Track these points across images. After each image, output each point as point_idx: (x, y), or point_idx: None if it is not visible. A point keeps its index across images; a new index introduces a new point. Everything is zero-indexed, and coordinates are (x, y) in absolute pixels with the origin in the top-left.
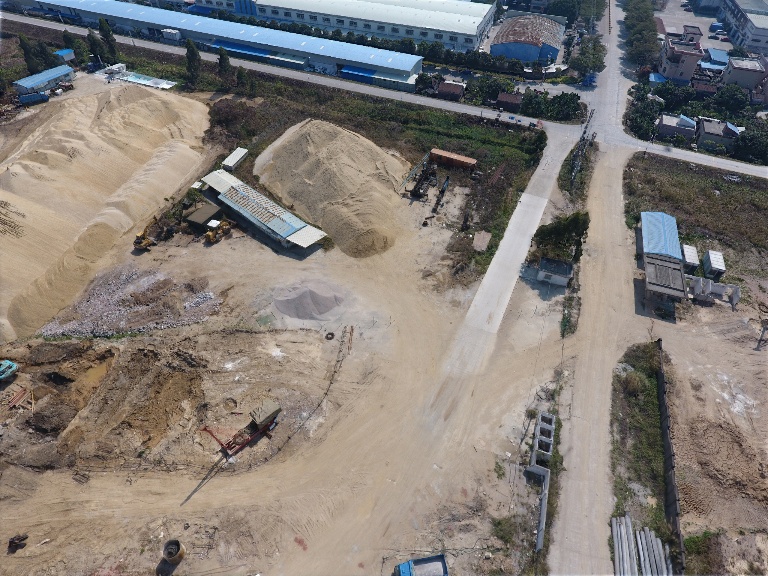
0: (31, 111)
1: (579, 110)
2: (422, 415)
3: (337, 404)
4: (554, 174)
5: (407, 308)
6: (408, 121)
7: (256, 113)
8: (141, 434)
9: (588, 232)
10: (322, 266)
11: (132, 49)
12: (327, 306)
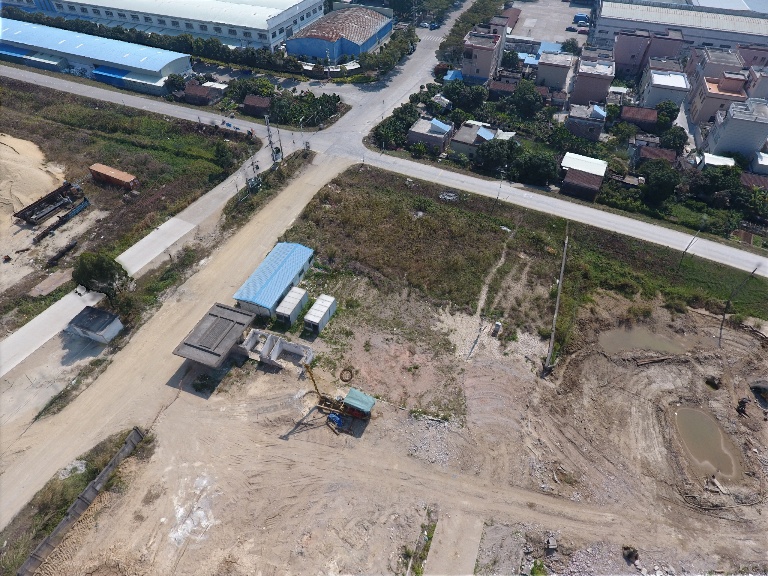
0: None
1: (335, 114)
2: None
3: None
4: (231, 193)
5: None
6: (117, 129)
7: None
8: None
9: (207, 268)
10: None
11: None
12: None
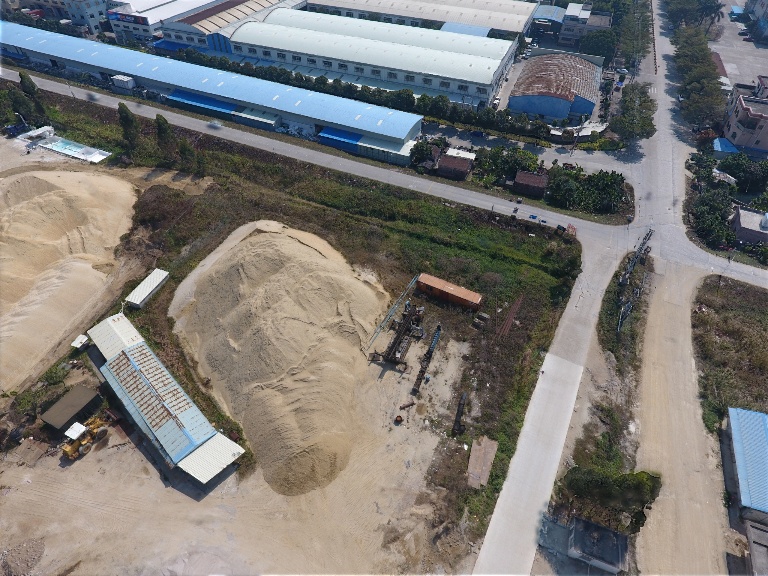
0: None
1: (623, 197)
2: None
3: None
4: (592, 316)
5: None
6: (395, 216)
7: (195, 206)
8: None
9: (646, 440)
10: (228, 515)
11: (71, 103)
12: None
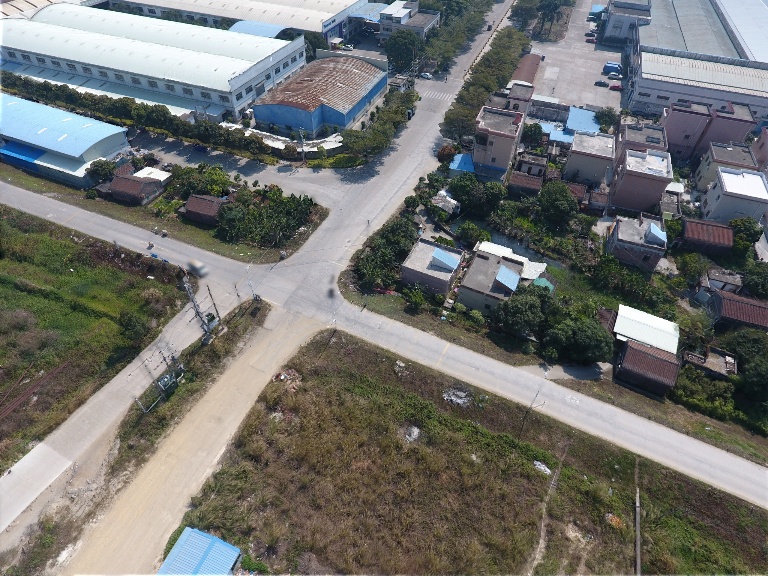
0: None
1: (306, 226)
2: None
3: None
4: (138, 388)
5: None
6: (4, 254)
7: None
8: None
9: (67, 575)
10: None
11: None
12: None
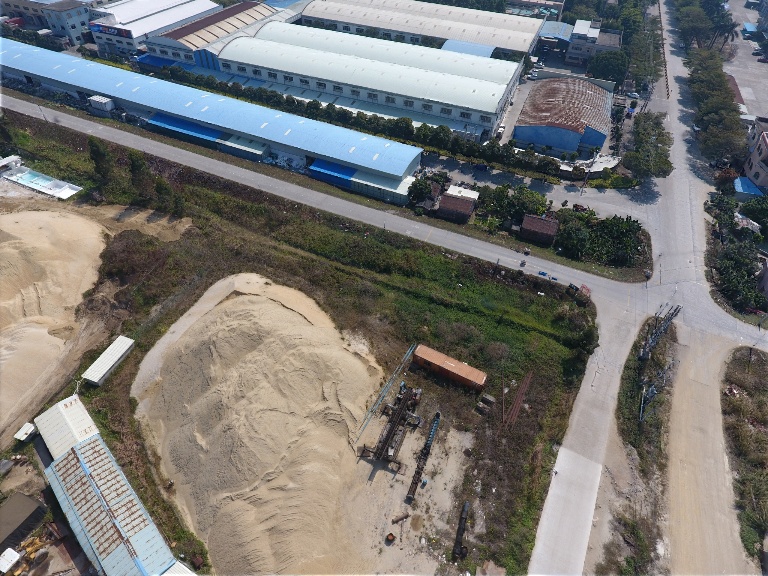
0: None
1: (639, 246)
2: None
3: None
4: (610, 398)
5: None
6: (390, 268)
7: (169, 255)
8: None
9: (677, 566)
10: None
11: (43, 127)
12: None
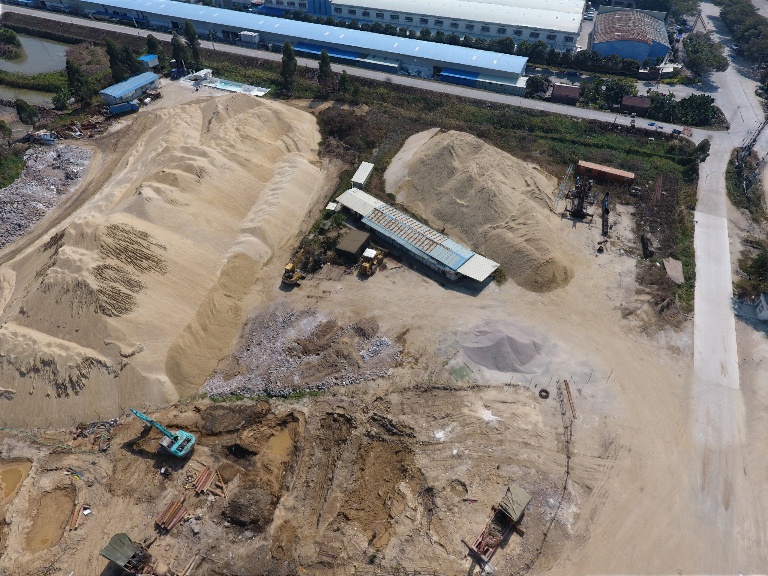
0: (123, 123)
1: None
2: (695, 502)
3: (586, 487)
4: (721, 188)
5: (620, 356)
6: (533, 129)
7: None
8: (362, 529)
9: None
10: (502, 303)
11: (212, 53)
12: (528, 355)
